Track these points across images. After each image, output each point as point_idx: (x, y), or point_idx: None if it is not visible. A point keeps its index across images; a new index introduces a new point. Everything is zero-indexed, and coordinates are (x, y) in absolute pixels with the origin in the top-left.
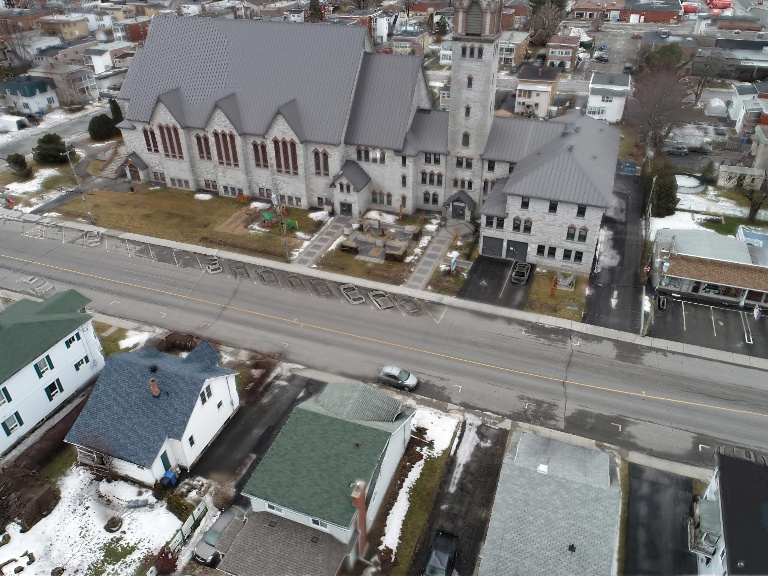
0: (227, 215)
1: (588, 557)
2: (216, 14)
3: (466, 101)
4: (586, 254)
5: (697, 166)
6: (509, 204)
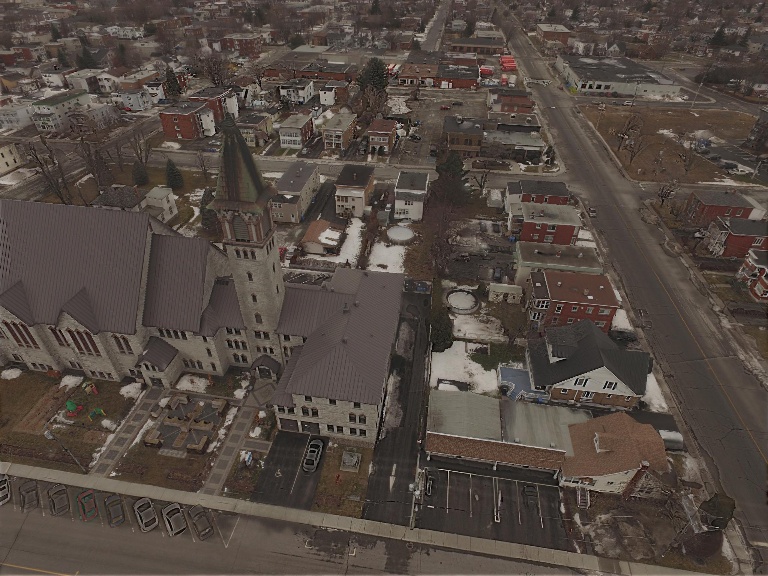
0: (32, 402)
1: None
2: (68, 97)
3: (251, 291)
4: (368, 431)
5: (475, 276)
6: (294, 398)
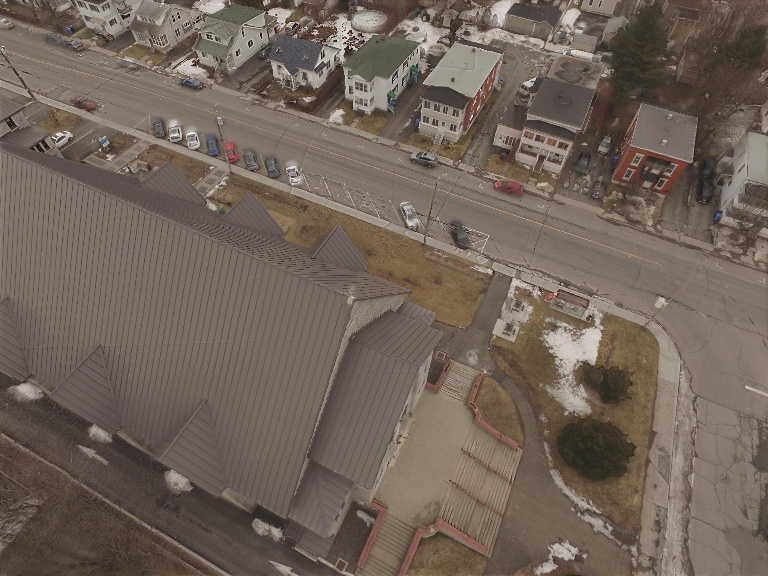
0: None
1: (166, 4)
2: None
3: None
4: None
5: None
6: None
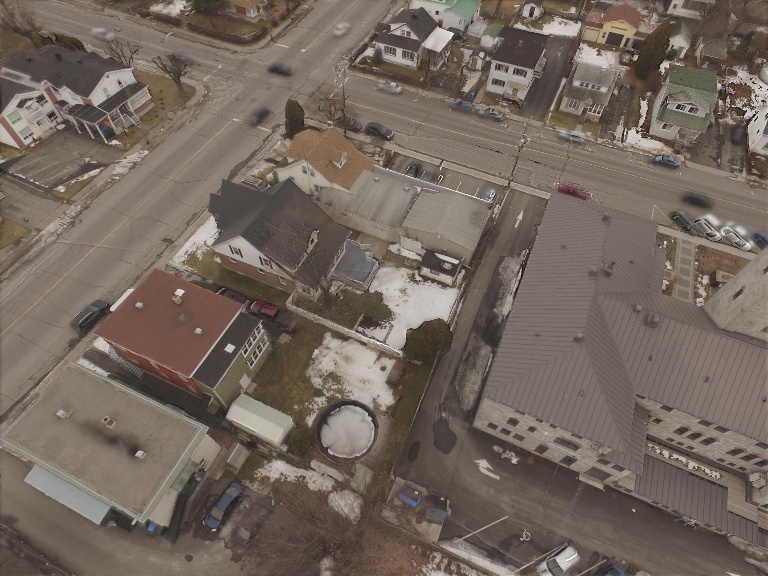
0: None
1: None
2: None
3: None
4: None
5: (273, 517)
6: None
